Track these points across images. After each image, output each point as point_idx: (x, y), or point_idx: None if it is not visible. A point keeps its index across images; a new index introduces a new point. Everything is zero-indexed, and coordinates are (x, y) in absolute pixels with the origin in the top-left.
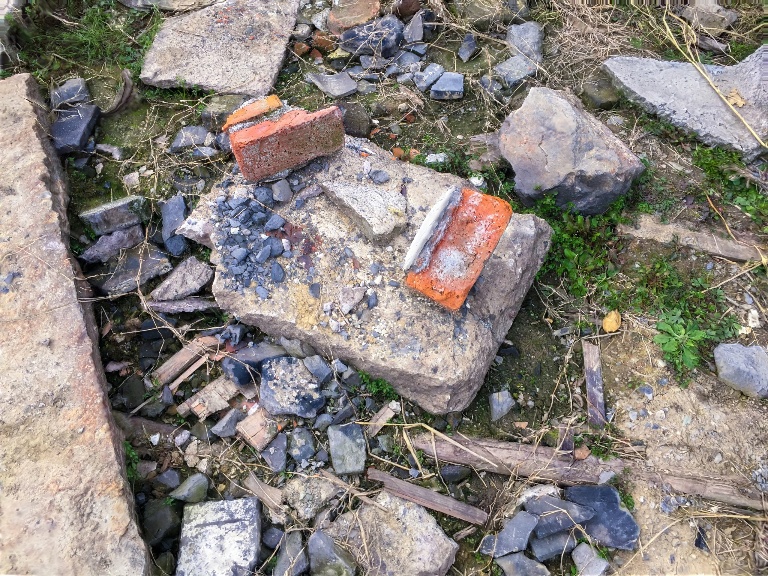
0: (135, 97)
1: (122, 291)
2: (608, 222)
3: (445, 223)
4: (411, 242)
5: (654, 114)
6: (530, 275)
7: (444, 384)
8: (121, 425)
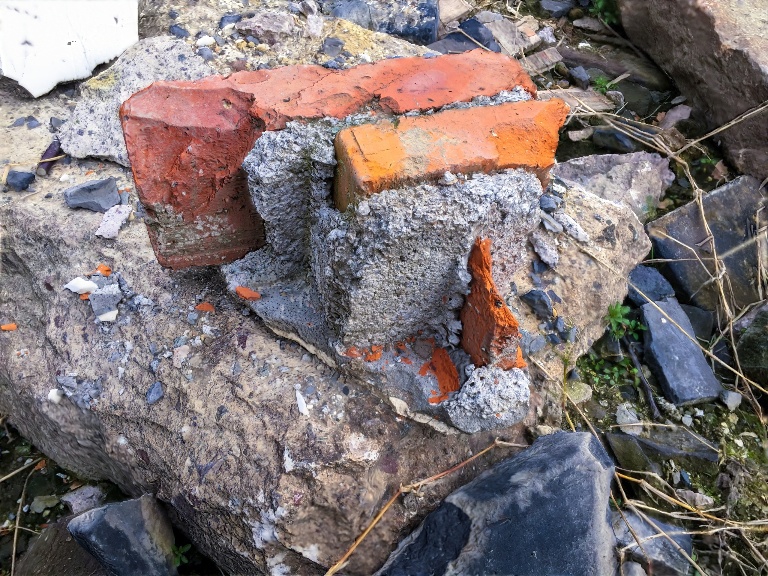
0: None
1: None
2: None
3: None
4: None
5: None
6: None
7: None
8: (637, 62)
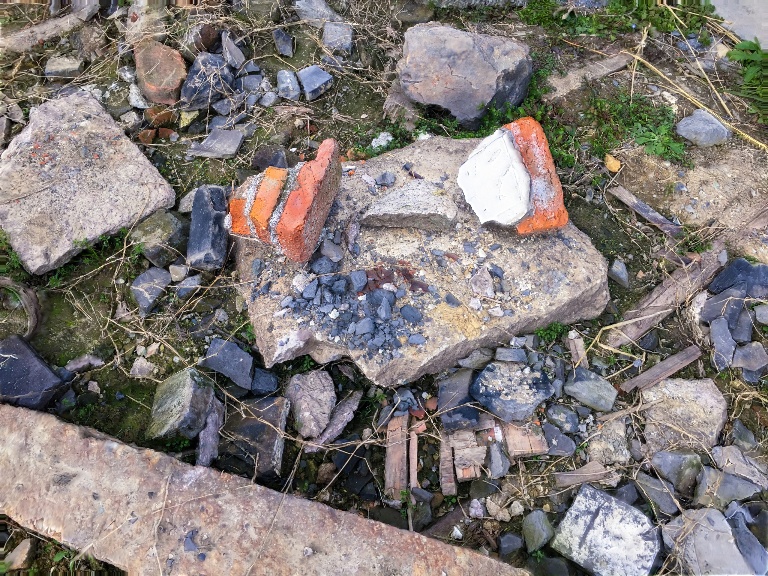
0: None
1: (279, 458)
2: (535, 100)
3: None
4: (466, 209)
5: (468, 7)
6: None
7: (601, 284)
8: None
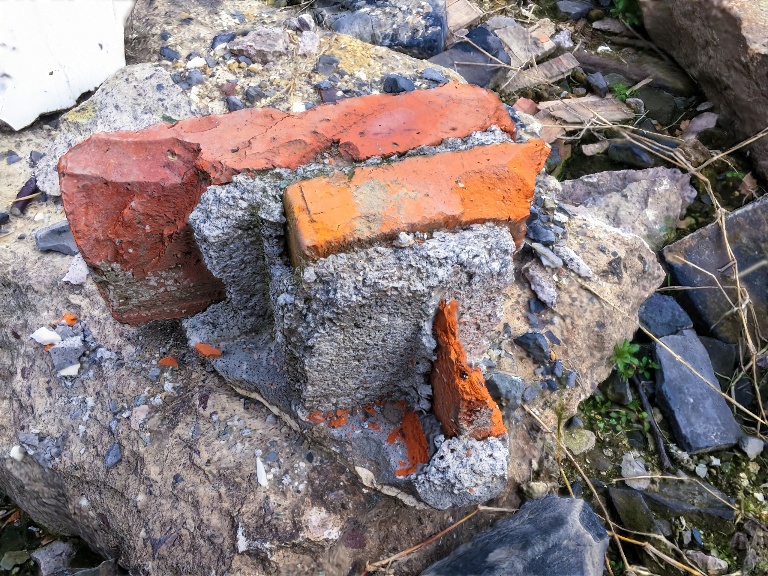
0: None
1: None
2: None
3: None
4: None
5: None
6: None
7: None
8: (661, 66)
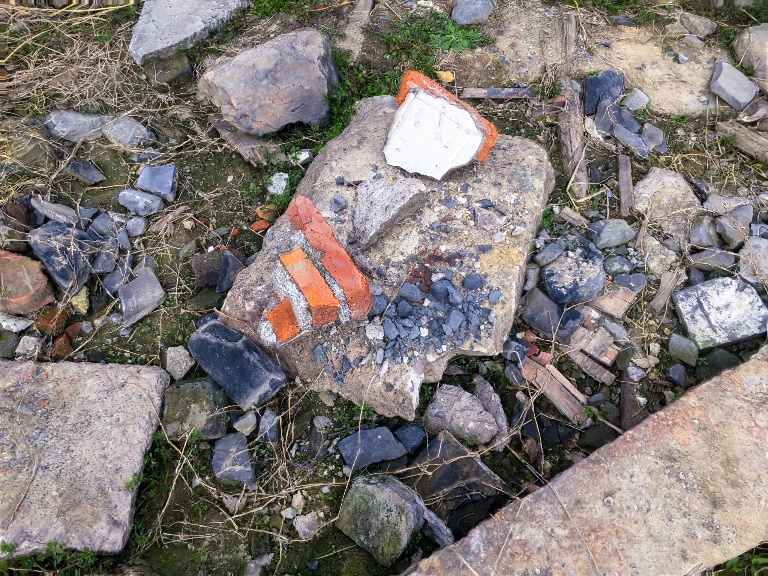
0: None
1: None
2: (346, 68)
3: None
4: None
5: (209, 34)
6: None
7: None
8: None
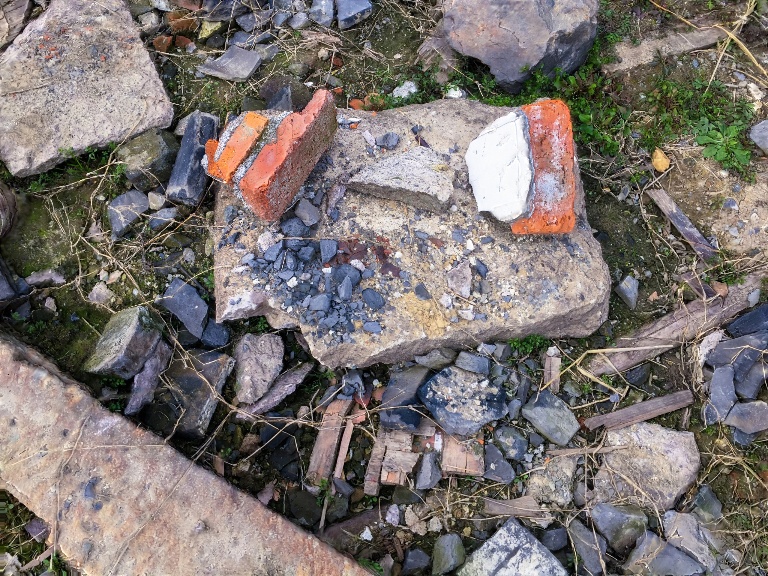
0: (17, 199)
1: (208, 418)
2: (593, 69)
3: (531, 154)
4: (467, 190)
5: None
6: (577, 158)
7: (595, 305)
8: None
